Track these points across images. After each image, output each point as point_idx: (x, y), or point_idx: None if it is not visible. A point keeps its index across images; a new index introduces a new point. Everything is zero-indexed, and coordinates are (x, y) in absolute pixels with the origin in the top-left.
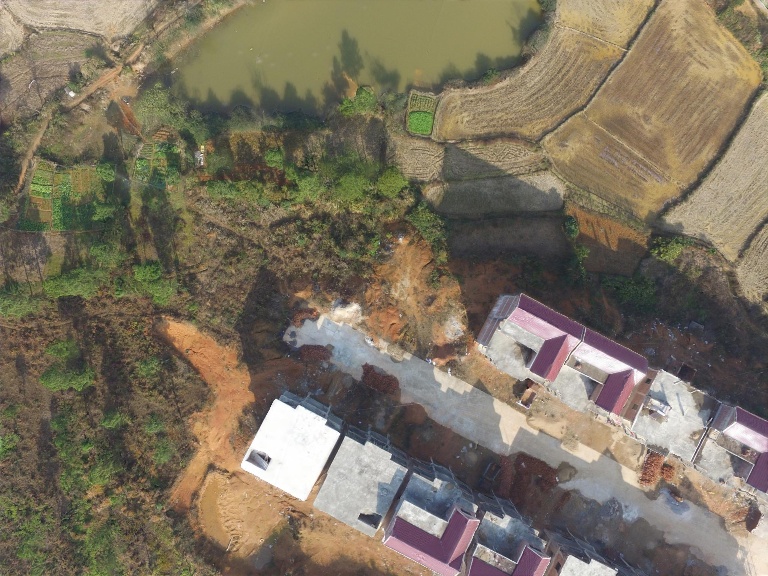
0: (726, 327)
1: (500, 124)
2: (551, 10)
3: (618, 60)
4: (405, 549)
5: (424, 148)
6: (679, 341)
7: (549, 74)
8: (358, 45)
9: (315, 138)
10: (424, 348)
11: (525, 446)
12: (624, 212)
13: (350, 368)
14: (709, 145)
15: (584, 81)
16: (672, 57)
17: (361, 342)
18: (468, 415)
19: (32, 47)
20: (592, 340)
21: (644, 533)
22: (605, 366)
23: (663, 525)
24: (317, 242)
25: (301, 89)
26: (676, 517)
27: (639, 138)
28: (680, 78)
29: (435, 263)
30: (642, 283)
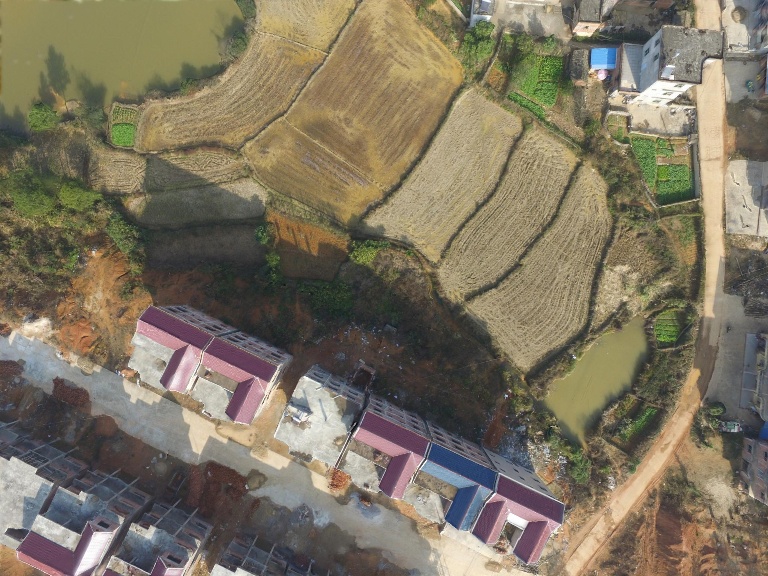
0: (417, 329)
1: (202, 133)
2: (250, 17)
3: (319, 64)
4: (32, 563)
5: (126, 160)
6: (371, 344)
7: (250, 81)
8: (64, 59)
9: (19, 154)
10: (115, 360)
11: (215, 455)
12: (326, 216)
13: (41, 382)
14: (411, 146)
15: (285, 87)
16: (373, 59)
17: (52, 356)
18: (158, 425)
19: None
20: (216, 349)
21: (335, 538)
22: (232, 375)
23: (354, 530)
24: (15, 258)
25: (9, 106)
26: (367, 521)
27: (341, 142)
28: (381, 80)
29: (131, 274)
30: (337, 287)
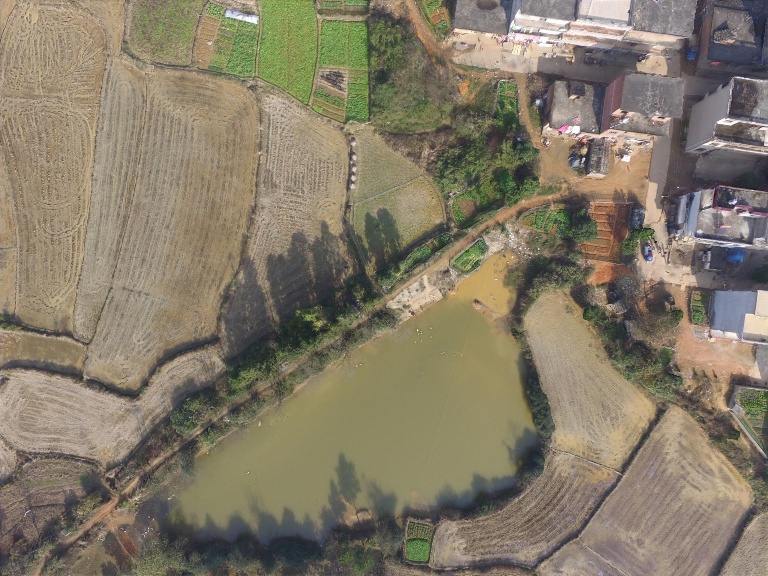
0: None
1: (496, 551)
2: (547, 437)
3: (613, 483)
4: None
5: None
6: None
7: (545, 499)
8: (355, 468)
9: (313, 568)
10: None
11: None
12: None
13: None
14: (700, 567)
15: (579, 505)
16: (666, 481)
17: None
18: None
19: (26, 476)
20: None
21: None
22: None
23: None
24: None
25: (298, 513)
26: None
27: (632, 562)
28: (673, 502)
29: None
30: None
